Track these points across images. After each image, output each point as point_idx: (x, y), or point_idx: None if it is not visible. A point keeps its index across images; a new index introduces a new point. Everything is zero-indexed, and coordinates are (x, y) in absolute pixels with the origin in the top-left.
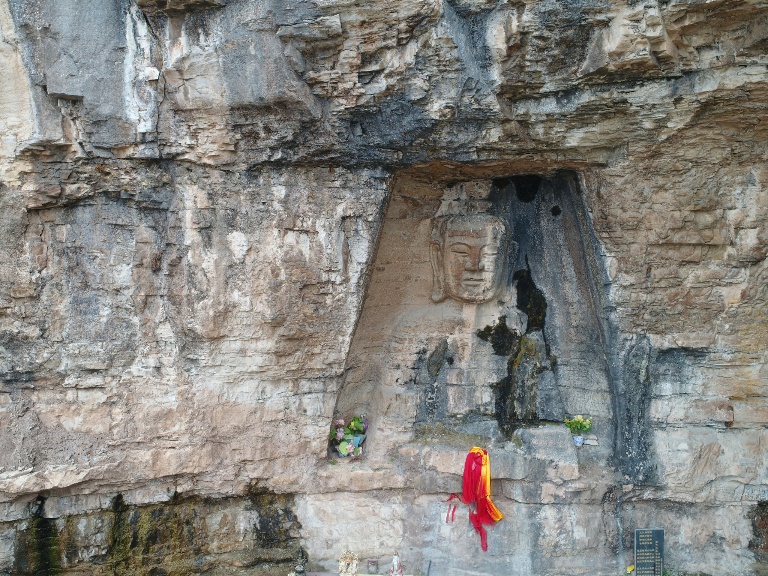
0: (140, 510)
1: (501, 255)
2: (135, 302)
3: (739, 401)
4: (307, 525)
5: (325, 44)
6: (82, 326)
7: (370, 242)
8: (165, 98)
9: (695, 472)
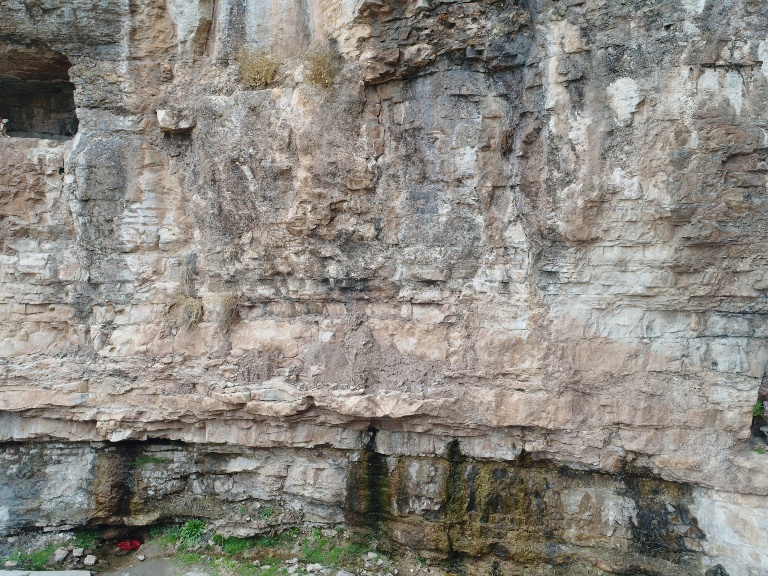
0: (479, 465)
1: None
2: (480, 196)
3: None
4: (714, 536)
5: None
6: (419, 227)
7: None
8: None
9: None
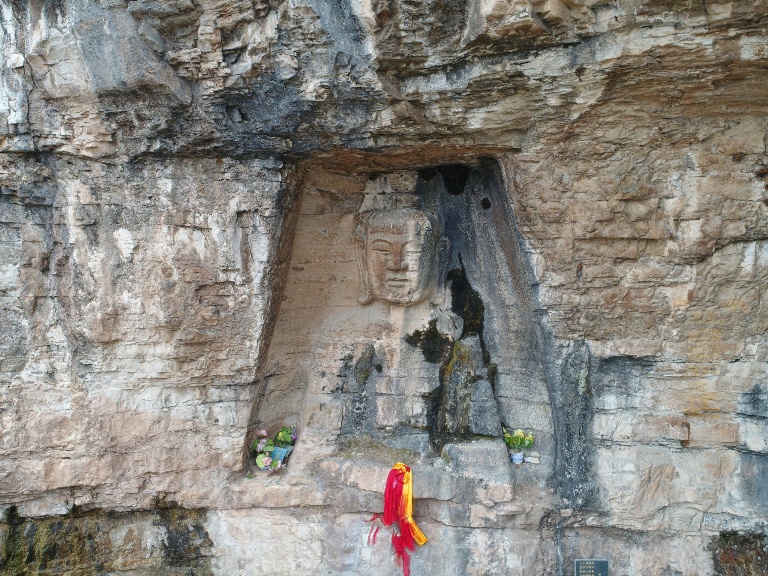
0: (38, 523)
1: (427, 253)
2: (23, 304)
3: (696, 417)
4: (219, 543)
5: (180, 20)
6: None
7: (269, 239)
8: (35, 86)
9: (644, 497)
